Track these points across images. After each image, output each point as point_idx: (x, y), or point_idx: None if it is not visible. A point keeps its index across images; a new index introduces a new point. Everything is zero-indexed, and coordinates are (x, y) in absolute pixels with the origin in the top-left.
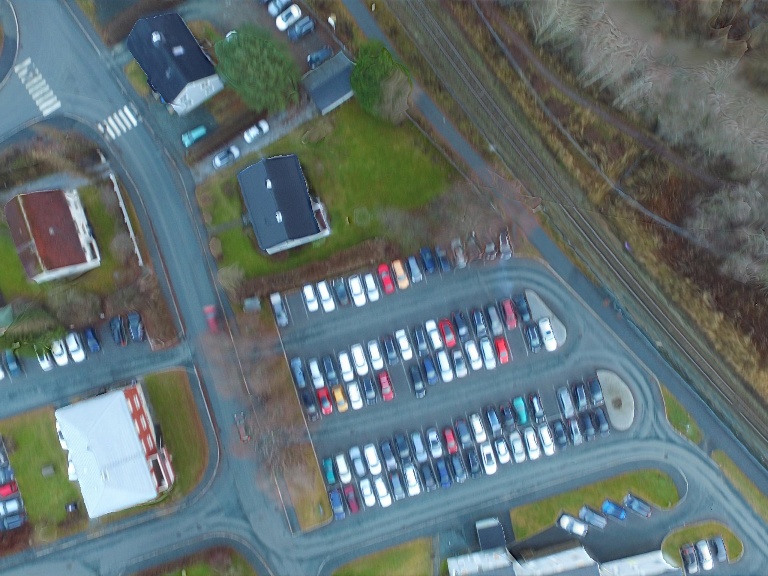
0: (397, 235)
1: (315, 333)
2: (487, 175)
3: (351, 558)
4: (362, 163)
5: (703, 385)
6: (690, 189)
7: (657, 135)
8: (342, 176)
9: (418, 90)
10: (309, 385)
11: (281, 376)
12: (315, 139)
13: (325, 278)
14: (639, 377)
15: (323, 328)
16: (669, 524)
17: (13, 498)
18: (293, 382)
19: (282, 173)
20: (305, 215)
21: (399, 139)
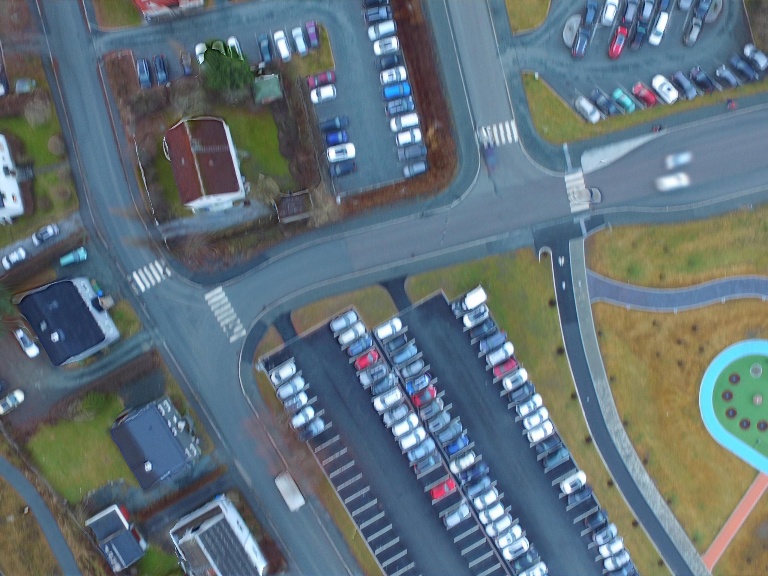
0: None
1: None
2: None
3: None
4: None
5: None
6: None
7: None
8: None
9: None
10: None
11: (2, 13)
12: None
13: None
14: None
15: None
16: None
17: None
18: None
19: None
20: None
21: None
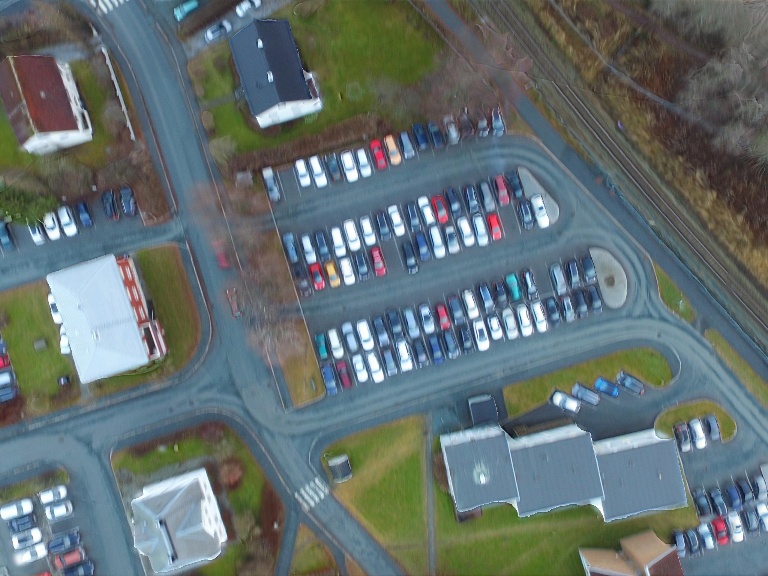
0: (389, 110)
1: (307, 209)
2: (479, 51)
3: (343, 434)
4: (354, 39)
5: (696, 265)
6: (683, 67)
7: (650, 10)
8: (334, 52)
9: None
10: (301, 261)
11: (273, 252)
12: (307, 11)
13: (317, 153)
14: (632, 255)
15: (315, 204)
16: (662, 403)
17: (5, 371)
18: (285, 258)
19: (273, 35)
20: (296, 80)
21: (391, 15)
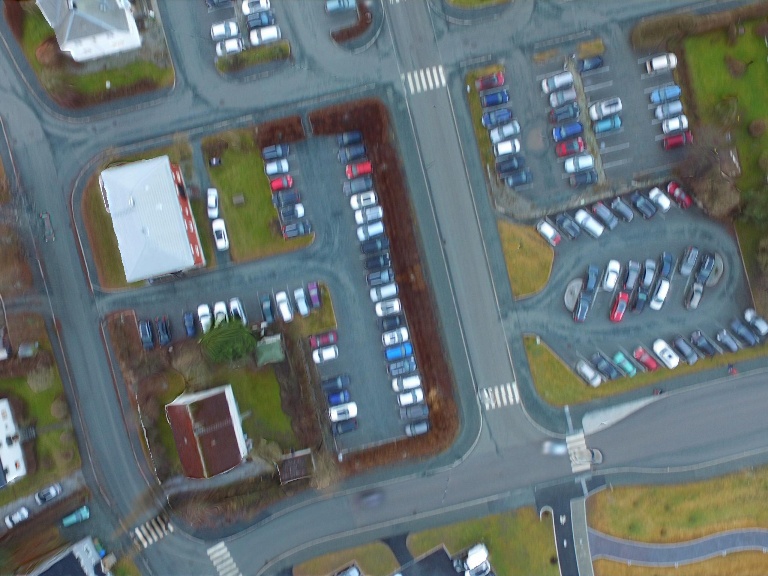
0: None
1: None
2: None
3: None
4: None
5: None
6: None
7: None
8: None
9: None
10: None
11: (5, 276)
12: None
13: None
14: None
15: None
16: None
17: None
18: None
19: None
20: None
21: None
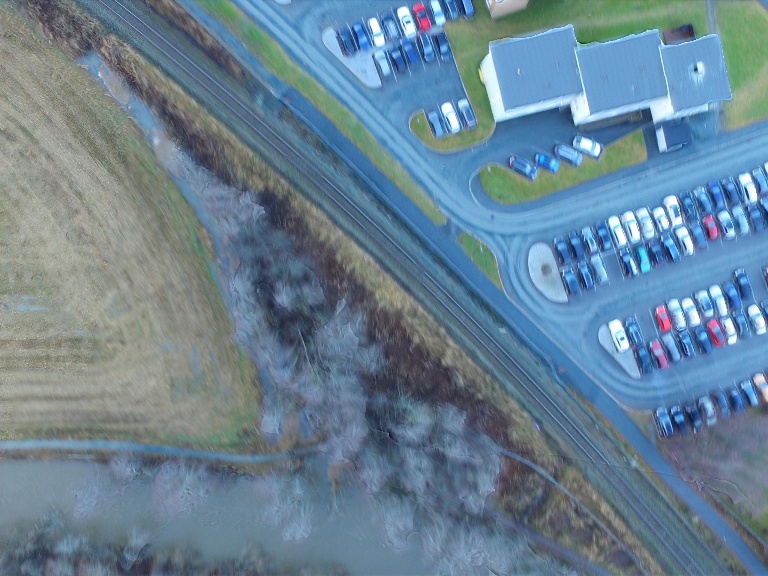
0: None
1: None
2: (683, 488)
3: None
4: None
5: (456, 290)
6: None
7: None
8: None
9: (751, 565)
10: None
11: None
12: None
13: None
14: (525, 297)
15: None
16: (488, 149)
17: None
18: None
19: None
20: None
21: (766, 517)
